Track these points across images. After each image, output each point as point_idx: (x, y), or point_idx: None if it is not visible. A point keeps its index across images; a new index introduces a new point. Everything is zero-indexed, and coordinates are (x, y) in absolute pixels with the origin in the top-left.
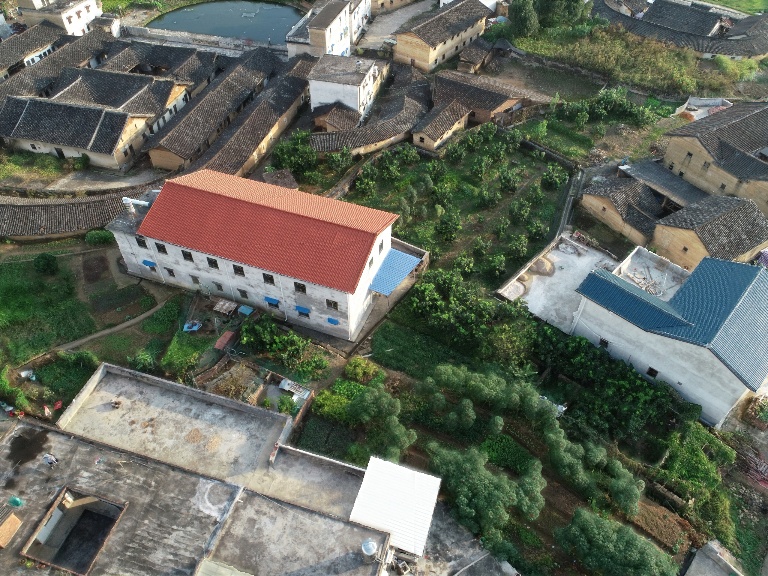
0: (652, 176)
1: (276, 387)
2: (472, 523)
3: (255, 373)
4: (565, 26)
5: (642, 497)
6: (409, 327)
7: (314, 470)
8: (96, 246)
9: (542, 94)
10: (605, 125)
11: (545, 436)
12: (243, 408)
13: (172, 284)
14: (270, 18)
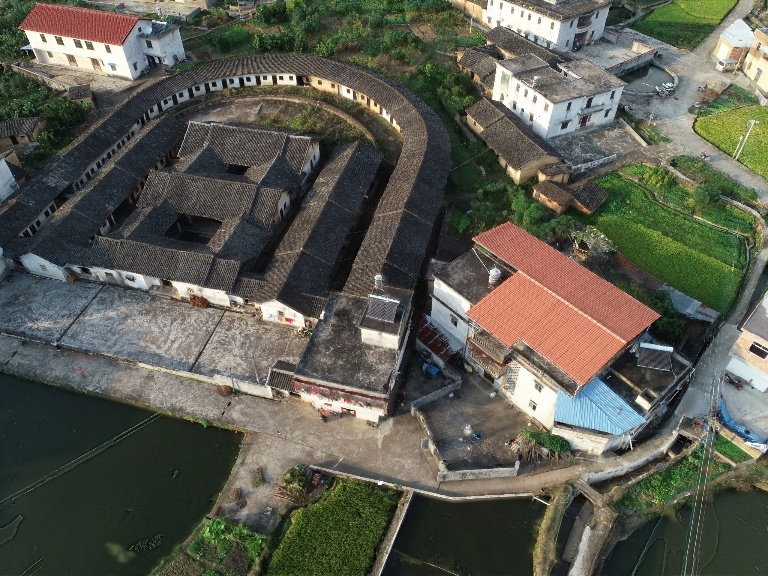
0: None
1: None
2: None
3: None
4: None
5: None
6: None
7: None
8: None
9: None
10: None
11: None
12: None
13: None
14: None
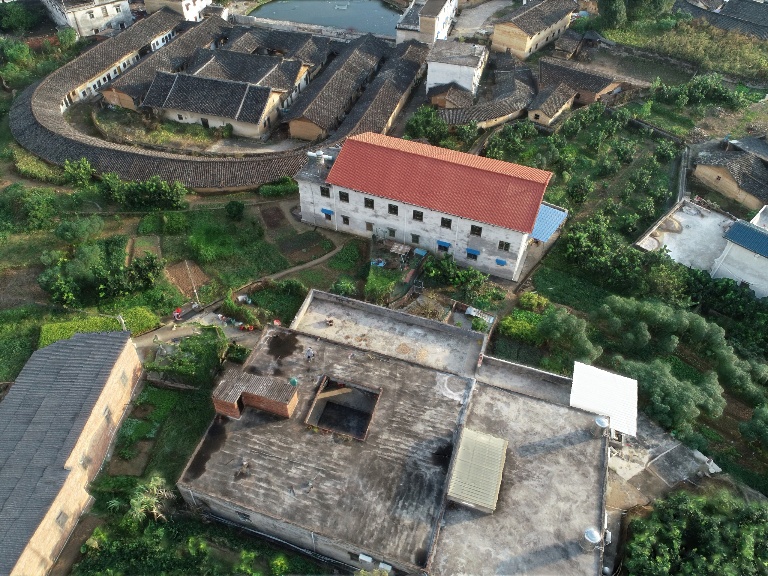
0: (760, 150)
1: (461, 314)
2: (667, 417)
3: (439, 303)
4: (650, 20)
5: None
6: (562, 271)
7: (515, 377)
8: (269, 199)
9: (638, 80)
10: None
11: (708, 357)
12: (442, 328)
13: (344, 231)
14: (362, 10)
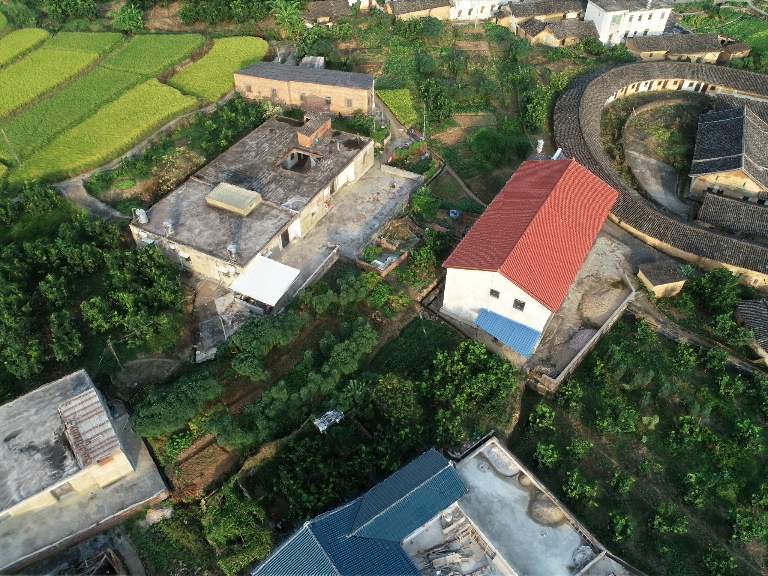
0: None
1: None
2: (243, 326)
3: None
4: None
5: (225, 467)
6: None
7: None
8: None
9: None
10: None
11: None
12: None
13: None
14: None
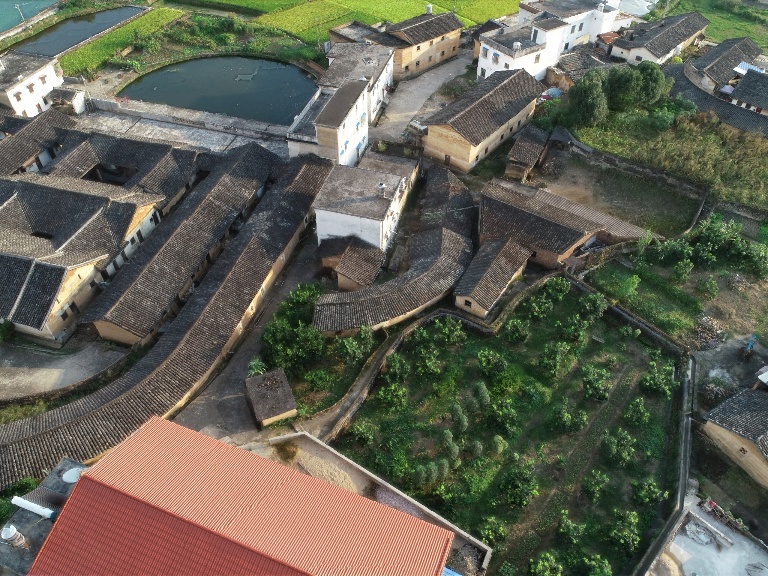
0: None
1: None
2: None
3: None
4: (640, 110)
5: None
6: None
7: None
8: None
9: None
10: (712, 273)
11: None
12: None
13: None
14: (270, 83)
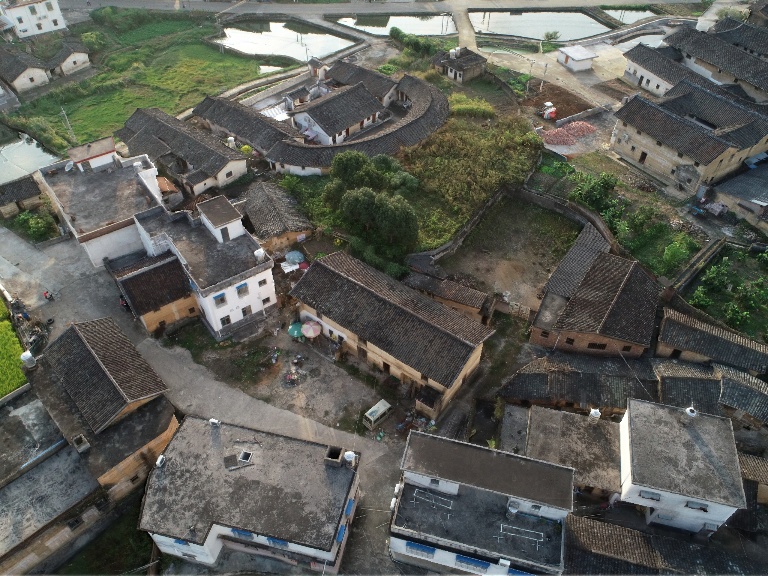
0: (757, 191)
1: None
2: None
3: None
4: None
5: None
6: None
7: None
8: None
9: None
10: None
11: None
12: None
13: None
14: None
